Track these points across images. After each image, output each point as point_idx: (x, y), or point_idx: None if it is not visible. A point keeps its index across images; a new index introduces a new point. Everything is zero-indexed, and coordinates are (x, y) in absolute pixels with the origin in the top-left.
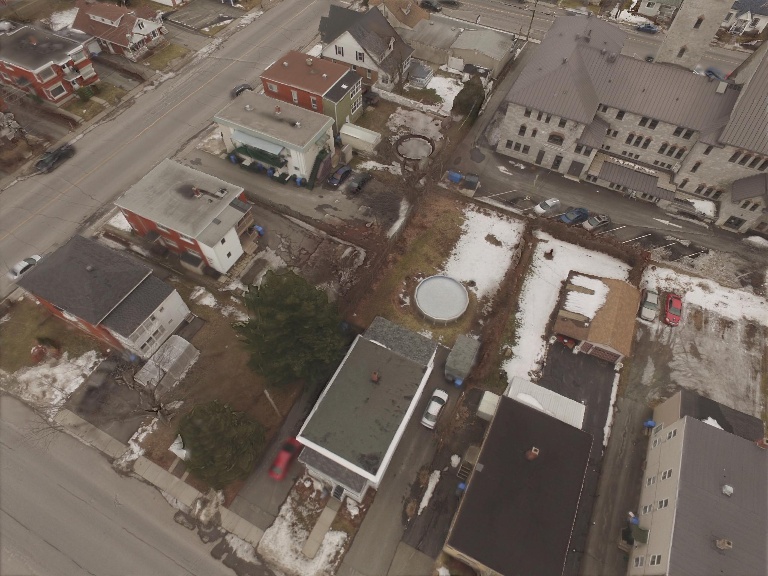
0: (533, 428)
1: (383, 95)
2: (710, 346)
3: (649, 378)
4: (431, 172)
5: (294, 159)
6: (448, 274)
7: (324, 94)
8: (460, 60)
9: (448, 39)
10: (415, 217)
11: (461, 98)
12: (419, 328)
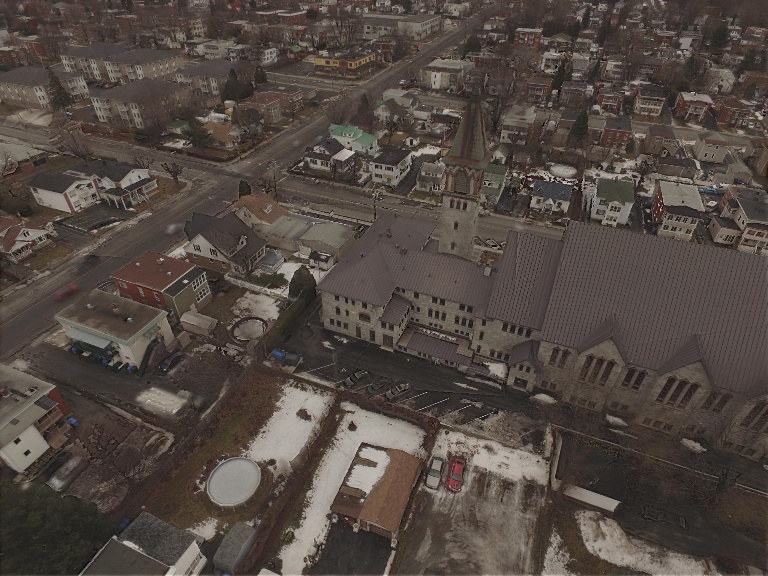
0: None
1: (236, 281)
2: (488, 511)
3: (424, 553)
4: (255, 352)
5: (123, 350)
6: (251, 454)
7: (164, 290)
8: (308, 248)
9: (300, 232)
10: (234, 397)
11: (292, 284)
12: (206, 516)
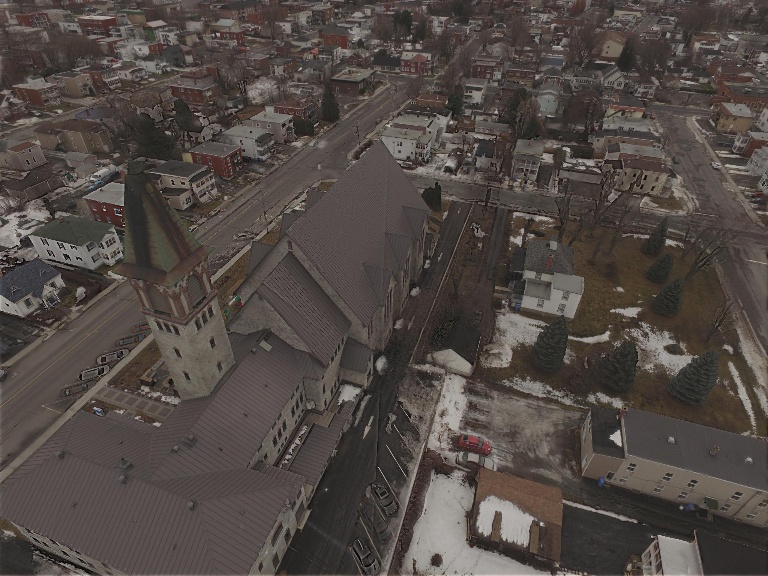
0: None
1: None
2: (500, 423)
3: (553, 475)
4: None
5: None
6: None
7: None
8: None
9: None
10: None
11: None
12: None
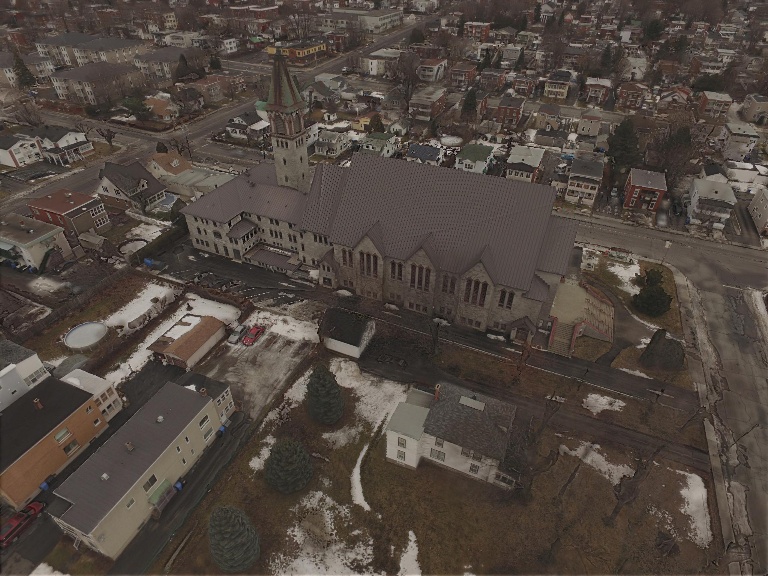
0: (56, 393)
1: None
2: (267, 357)
3: None
4: (130, 260)
5: (25, 254)
6: (107, 322)
7: (65, 213)
8: (201, 193)
9: (198, 181)
10: (107, 289)
11: (171, 214)
12: (60, 355)
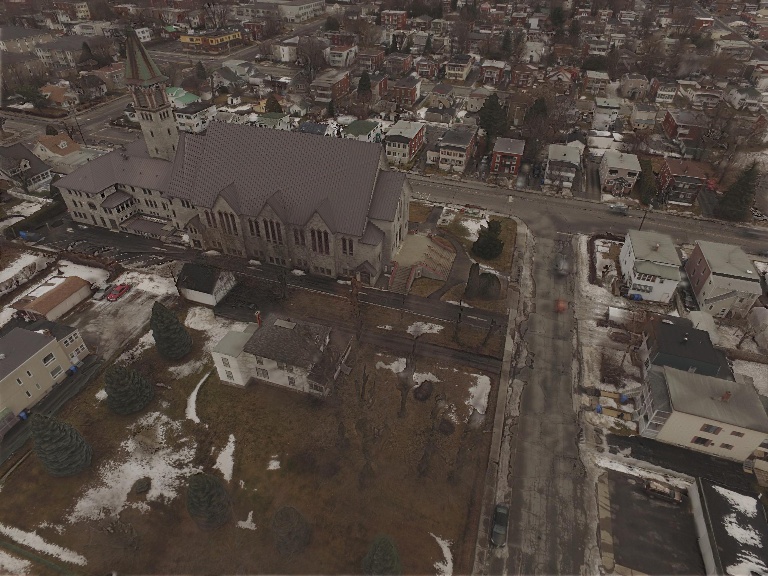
0: None
1: None
2: (129, 309)
3: None
4: (5, 233)
5: None
6: None
7: None
8: None
9: (85, 161)
10: None
11: (50, 190)
12: None
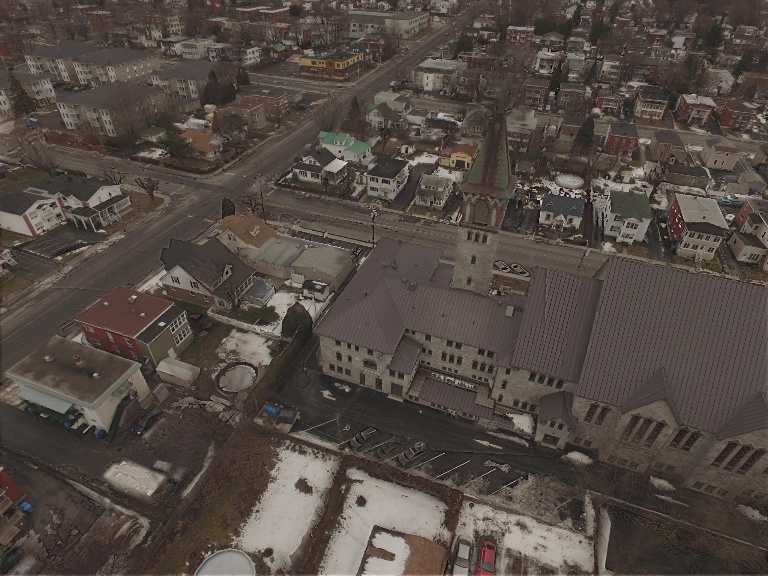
0: None
1: None
2: None
3: None
4: (245, 409)
5: (88, 413)
6: (243, 542)
7: (137, 335)
8: (301, 276)
9: (291, 257)
10: (221, 465)
11: (285, 324)
12: None
